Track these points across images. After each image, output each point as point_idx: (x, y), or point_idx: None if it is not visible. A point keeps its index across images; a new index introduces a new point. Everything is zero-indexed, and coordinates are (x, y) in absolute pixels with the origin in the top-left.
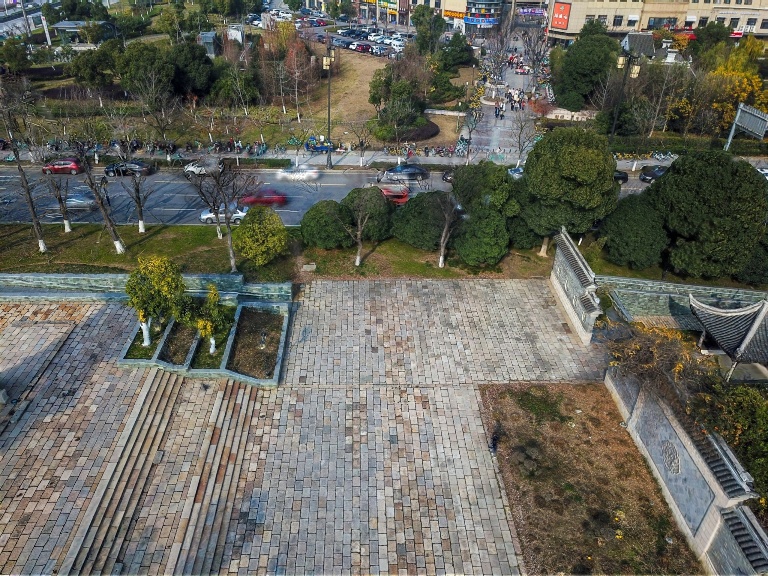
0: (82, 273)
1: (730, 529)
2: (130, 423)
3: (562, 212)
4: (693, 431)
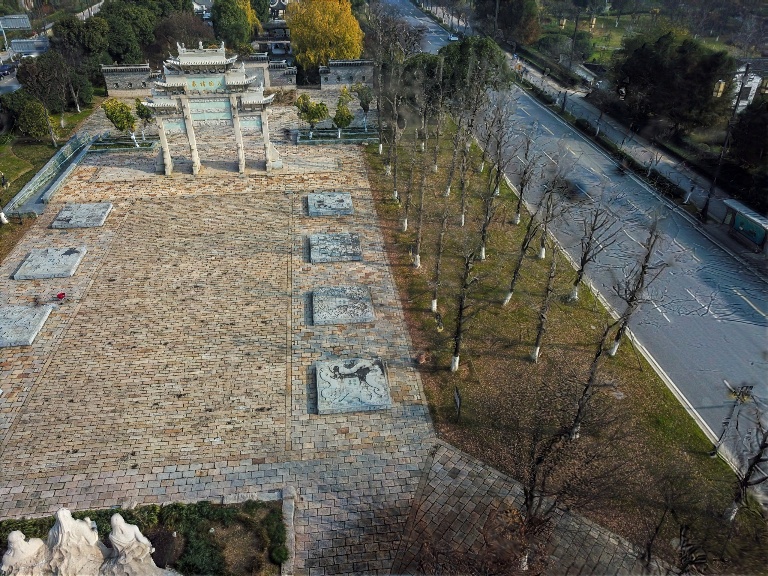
0: (38, 172)
1: (274, 67)
2: (197, 143)
3: (99, 56)
4: (246, 59)
